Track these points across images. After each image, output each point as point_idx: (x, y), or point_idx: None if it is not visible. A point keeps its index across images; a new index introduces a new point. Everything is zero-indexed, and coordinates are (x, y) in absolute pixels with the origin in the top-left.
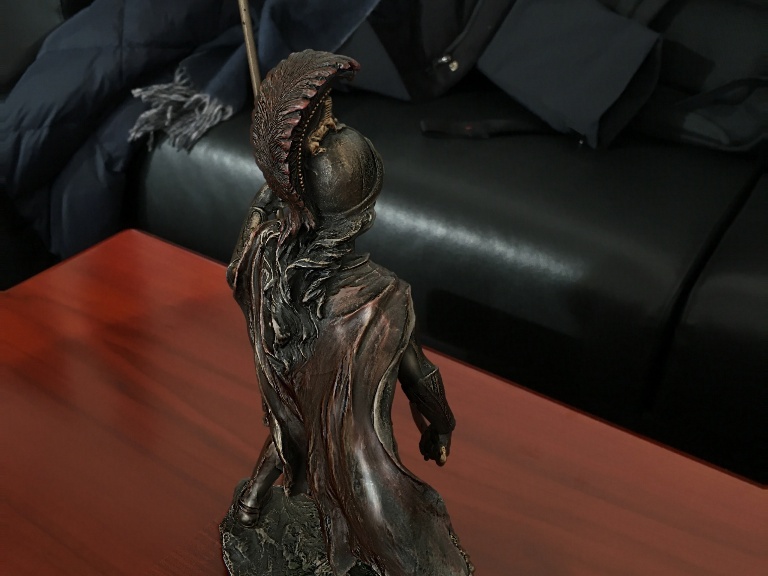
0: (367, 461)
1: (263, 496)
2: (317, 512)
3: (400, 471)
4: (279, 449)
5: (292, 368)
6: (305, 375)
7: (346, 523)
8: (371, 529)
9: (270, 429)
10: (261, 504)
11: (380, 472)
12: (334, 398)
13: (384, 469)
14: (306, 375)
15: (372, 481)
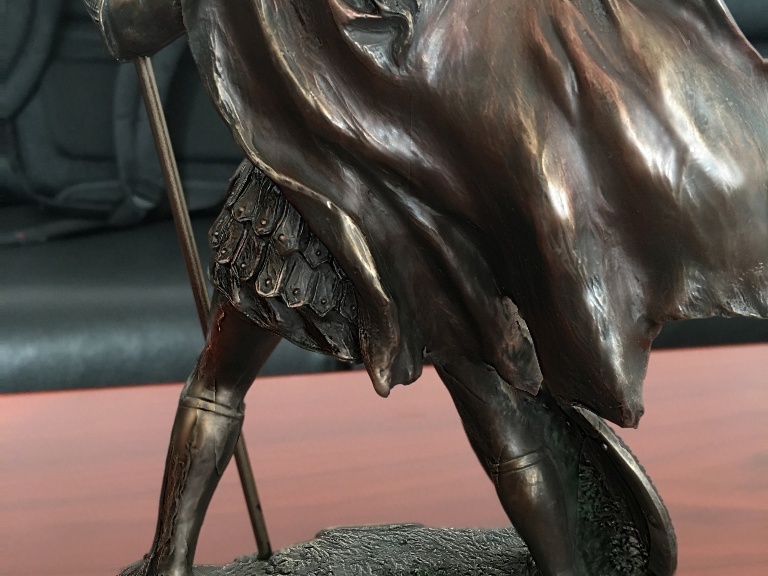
0: (705, 64)
1: (193, 551)
2: (256, 568)
3: (753, 68)
4: (371, 274)
5: (415, 30)
6: (452, 27)
7: (632, 274)
8: (754, 195)
9: (337, 244)
10: (191, 571)
11: (728, 80)
12: (570, 2)
13: (730, 74)
14: (455, 25)
15: (727, 98)
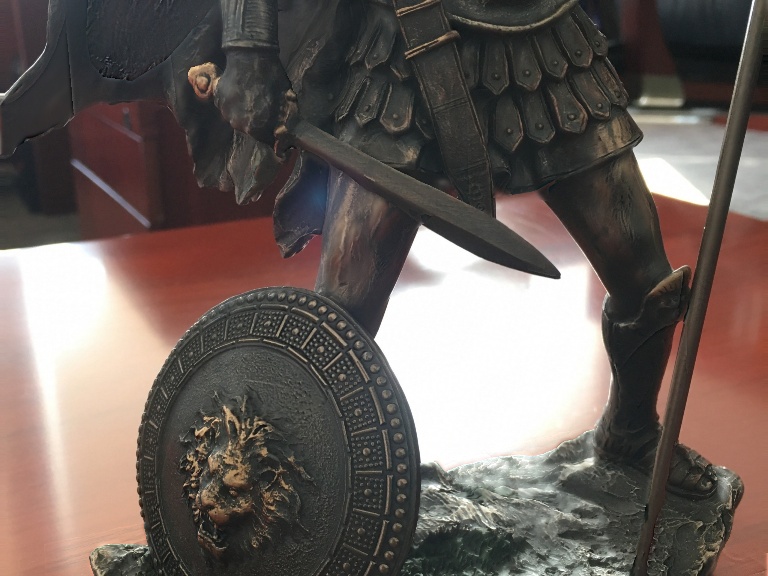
0: None
1: None
2: (631, 557)
3: None
4: None
5: None
6: None
7: None
8: (115, 2)
9: None
10: (614, 426)
11: None
12: None
13: None
14: None
15: None
